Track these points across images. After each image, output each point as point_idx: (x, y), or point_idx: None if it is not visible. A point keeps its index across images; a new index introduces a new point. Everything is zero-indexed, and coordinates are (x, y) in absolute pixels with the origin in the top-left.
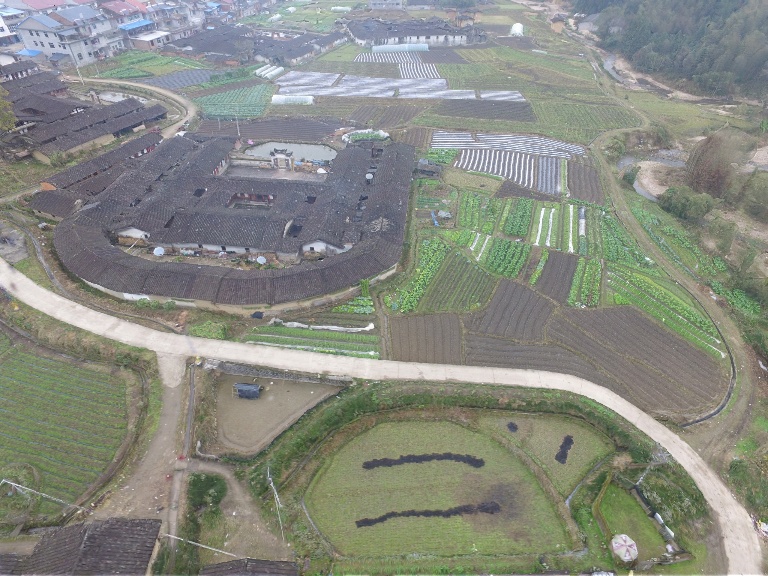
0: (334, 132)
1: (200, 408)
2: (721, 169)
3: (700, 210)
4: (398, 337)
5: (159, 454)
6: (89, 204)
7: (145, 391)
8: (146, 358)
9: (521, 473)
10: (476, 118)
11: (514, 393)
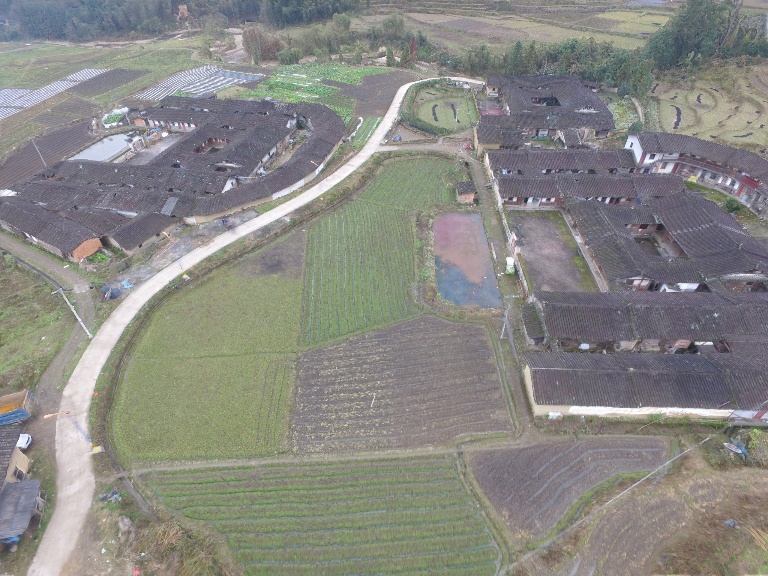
0: (85, 131)
1: (413, 140)
2: (276, 40)
3: (302, 54)
4: (369, 114)
5: (435, 147)
6: (162, 209)
7: (399, 155)
8: (378, 155)
9: (440, 100)
10: (124, 84)
11: (410, 92)
